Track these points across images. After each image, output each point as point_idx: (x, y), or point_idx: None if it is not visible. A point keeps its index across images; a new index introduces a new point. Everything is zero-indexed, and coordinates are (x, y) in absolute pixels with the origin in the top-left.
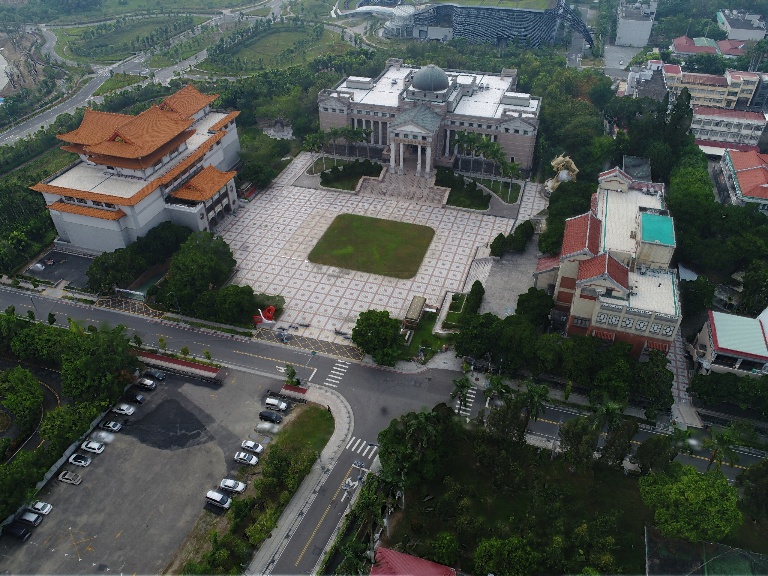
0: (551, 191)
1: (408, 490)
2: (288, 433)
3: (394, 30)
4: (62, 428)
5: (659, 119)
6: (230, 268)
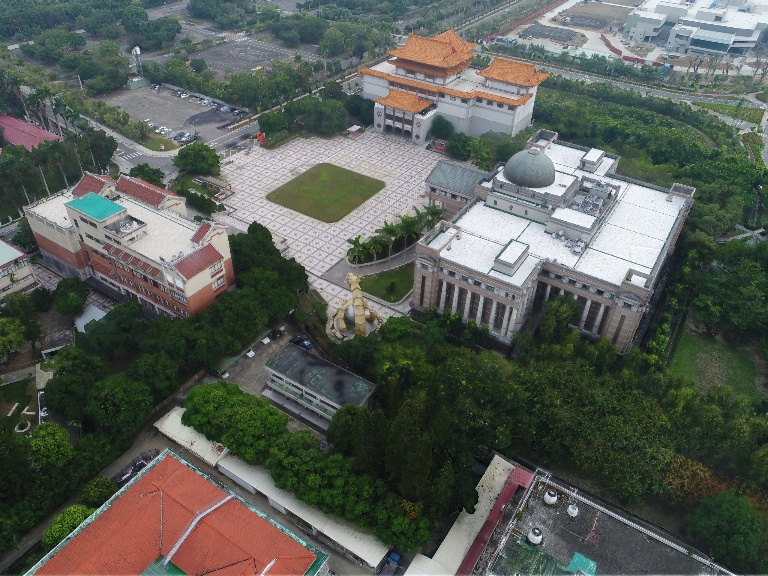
0: None
1: None
2: None
3: None
4: None
5: None
6: None
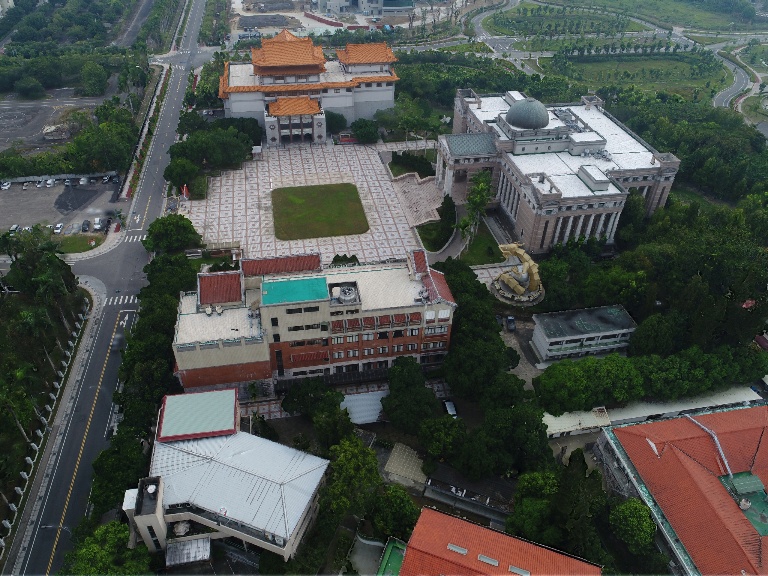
0: (496, 278)
1: None
2: (73, 237)
3: None
4: (42, 161)
5: None
6: (231, 162)
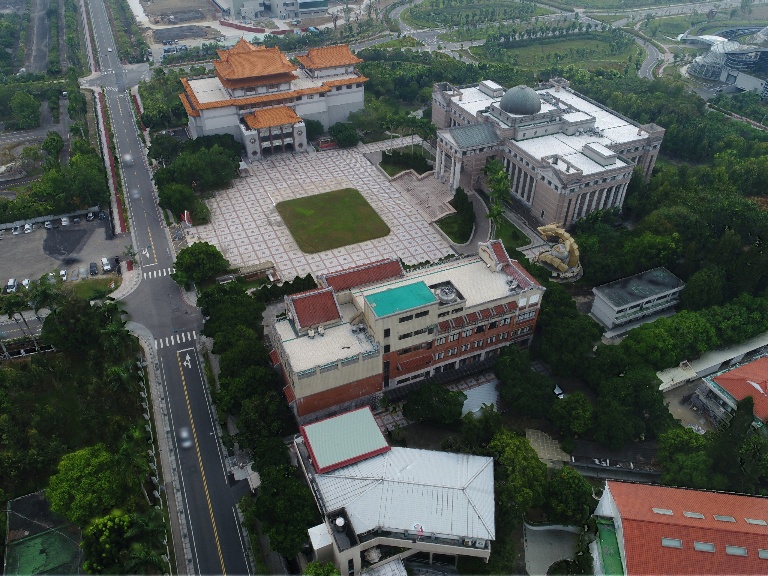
0: (535, 259)
1: (63, 352)
2: (84, 282)
3: (699, 66)
4: (15, 205)
5: (761, 249)
6: (222, 181)
